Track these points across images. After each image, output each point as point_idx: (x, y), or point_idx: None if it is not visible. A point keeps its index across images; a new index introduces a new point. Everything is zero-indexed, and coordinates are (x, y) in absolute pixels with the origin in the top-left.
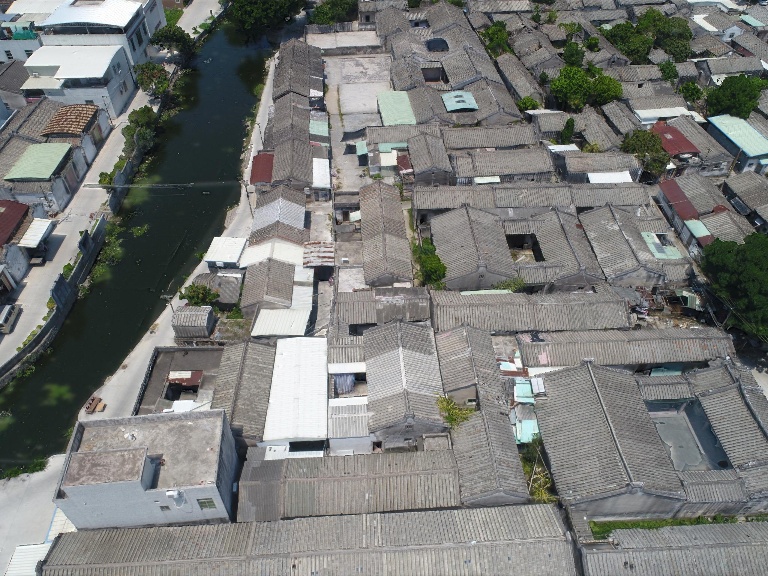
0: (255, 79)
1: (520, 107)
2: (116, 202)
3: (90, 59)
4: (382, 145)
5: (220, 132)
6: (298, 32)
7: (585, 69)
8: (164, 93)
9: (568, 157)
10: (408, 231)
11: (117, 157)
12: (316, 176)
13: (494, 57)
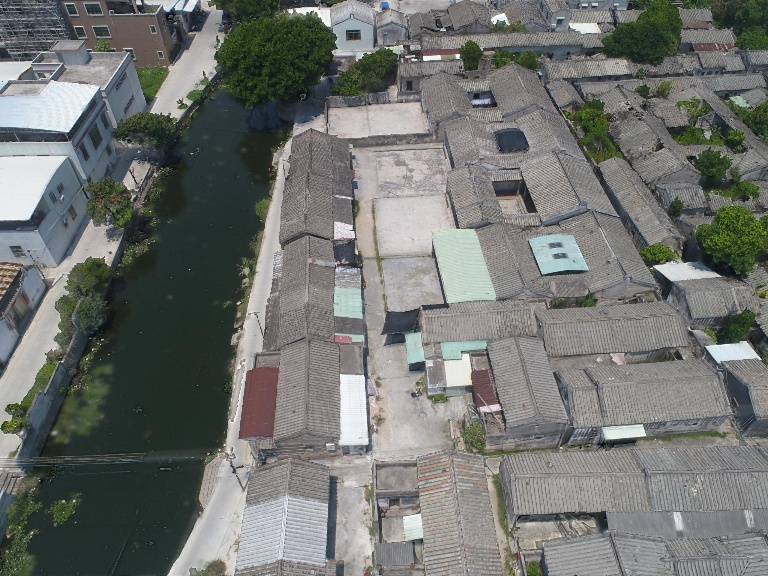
0: (258, 185)
1: (646, 258)
2: (33, 449)
3: (16, 184)
4: (447, 346)
5: (204, 289)
6: (317, 105)
7: (727, 180)
8: (126, 226)
9: (754, 389)
10: (498, 533)
11: (47, 347)
12: (345, 418)
13: (594, 161)
